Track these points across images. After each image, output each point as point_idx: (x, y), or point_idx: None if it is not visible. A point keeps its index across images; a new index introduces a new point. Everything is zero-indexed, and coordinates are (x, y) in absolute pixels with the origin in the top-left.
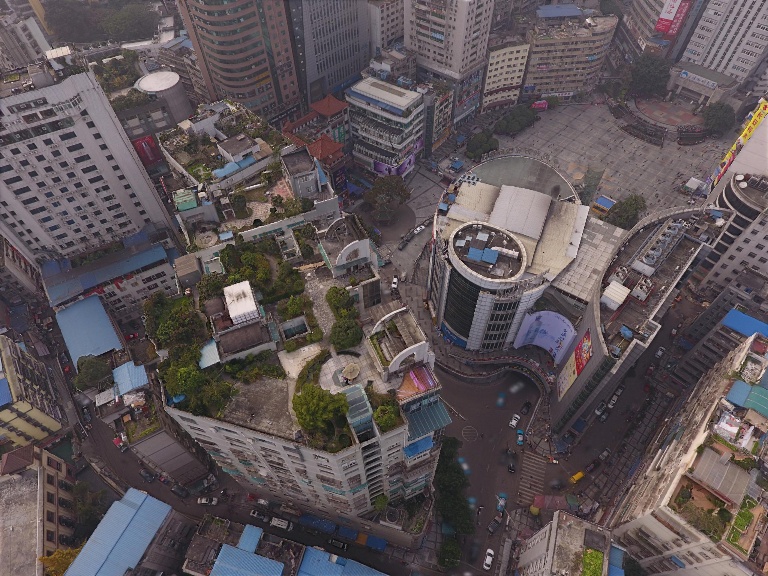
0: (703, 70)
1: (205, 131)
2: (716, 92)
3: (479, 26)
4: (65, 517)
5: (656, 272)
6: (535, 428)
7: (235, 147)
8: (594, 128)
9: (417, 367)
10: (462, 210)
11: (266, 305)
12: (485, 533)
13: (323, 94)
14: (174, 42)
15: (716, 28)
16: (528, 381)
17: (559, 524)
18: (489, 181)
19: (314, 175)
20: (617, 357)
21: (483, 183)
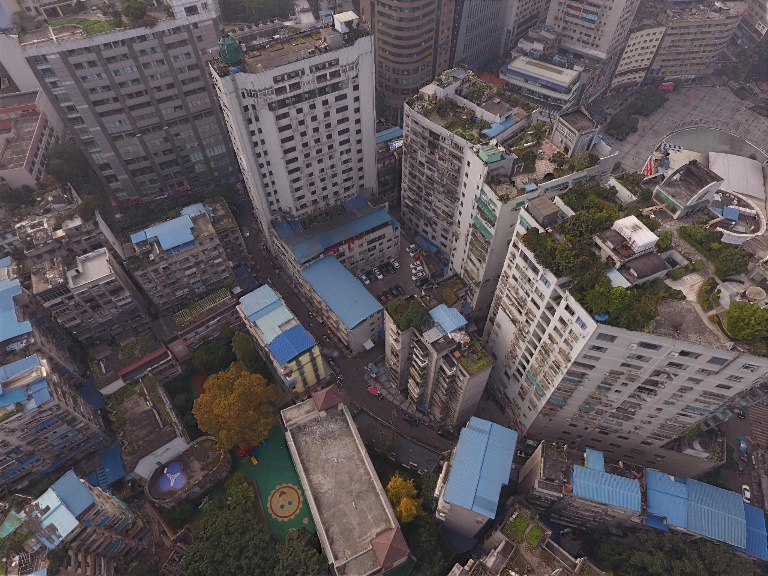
0: None
1: None
2: None
3: (631, 7)
4: None
5: None
6: None
7: (496, 109)
8: (723, 108)
9: None
10: None
11: None
12: None
13: None
14: None
15: None
16: None
17: None
18: None
19: (593, 133)
20: None
21: (688, 150)
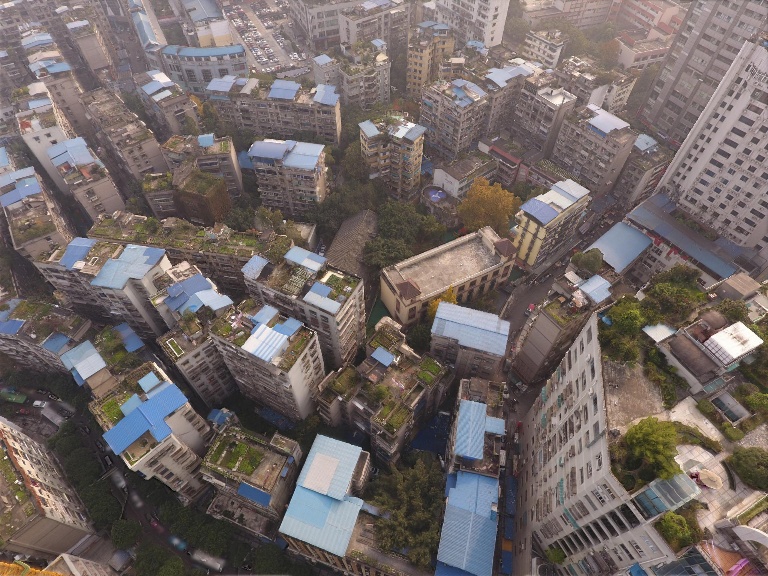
0: None
1: None
2: None
3: None
4: (473, 293)
5: None
6: None
7: None
8: None
9: (758, 569)
10: None
11: (739, 372)
12: None
13: None
14: None
15: None
16: None
17: None
18: None
19: None
20: None
21: None
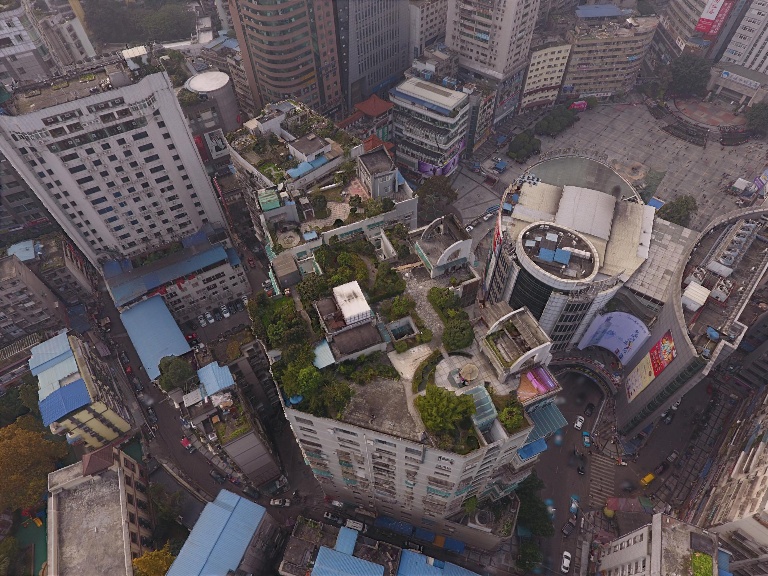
0: (744, 70)
1: (271, 131)
2: (759, 92)
3: (524, 26)
4: (143, 518)
5: (732, 273)
6: (601, 430)
7: (307, 147)
8: (635, 128)
9: (535, 368)
10: (526, 210)
11: None
12: (560, 535)
13: (362, 94)
14: (215, 42)
15: (759, 28)
16: (589, 382)
17: (663, 527)
18: (548, 181)
19: (393, 175)
20: (707, 358)
21: (544, 183)
